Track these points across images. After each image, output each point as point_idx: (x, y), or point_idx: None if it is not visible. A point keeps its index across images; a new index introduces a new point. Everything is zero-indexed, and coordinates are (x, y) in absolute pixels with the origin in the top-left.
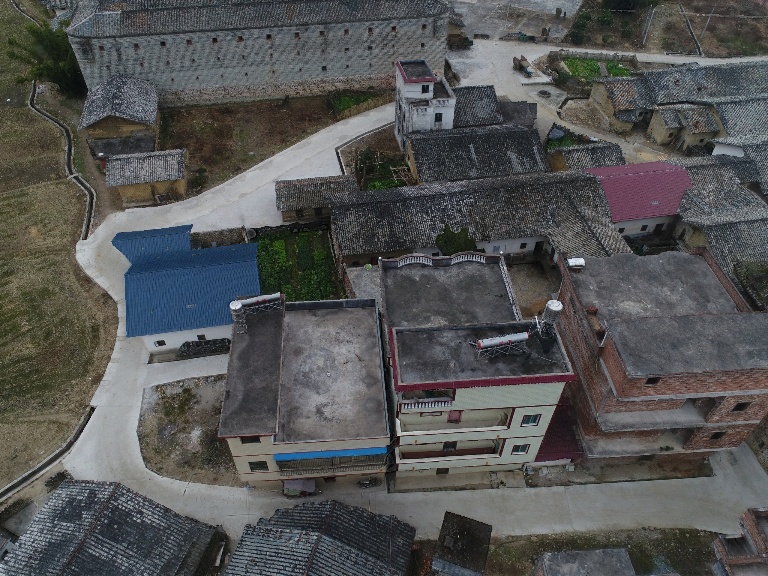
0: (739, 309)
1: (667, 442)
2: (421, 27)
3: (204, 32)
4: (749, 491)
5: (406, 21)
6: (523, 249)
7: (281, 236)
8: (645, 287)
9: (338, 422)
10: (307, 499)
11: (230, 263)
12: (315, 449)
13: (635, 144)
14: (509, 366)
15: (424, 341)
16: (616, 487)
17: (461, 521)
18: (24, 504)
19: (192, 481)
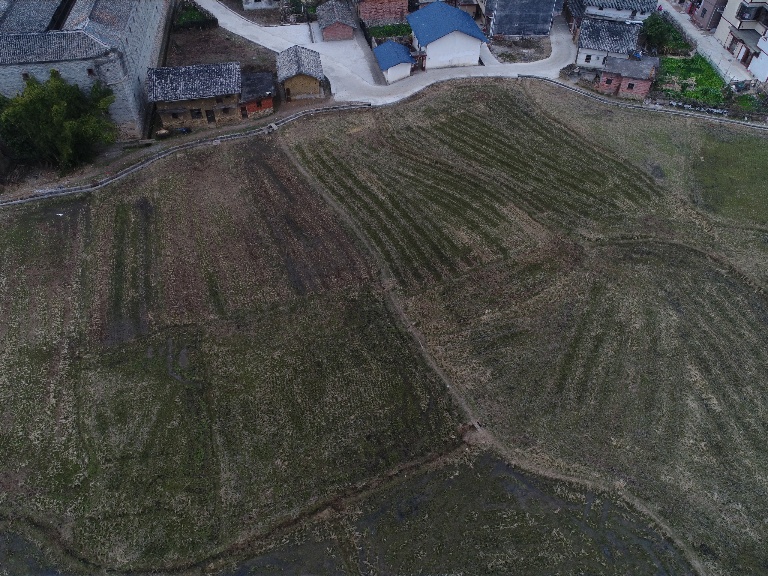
0: None
1: None
2: None
3: None
4: None
5: None
6: None
7: None
8: None
9: None
10: None
11: None
12: None
13: None
14: None
15: None
16: None
17: None
18: None
19: None
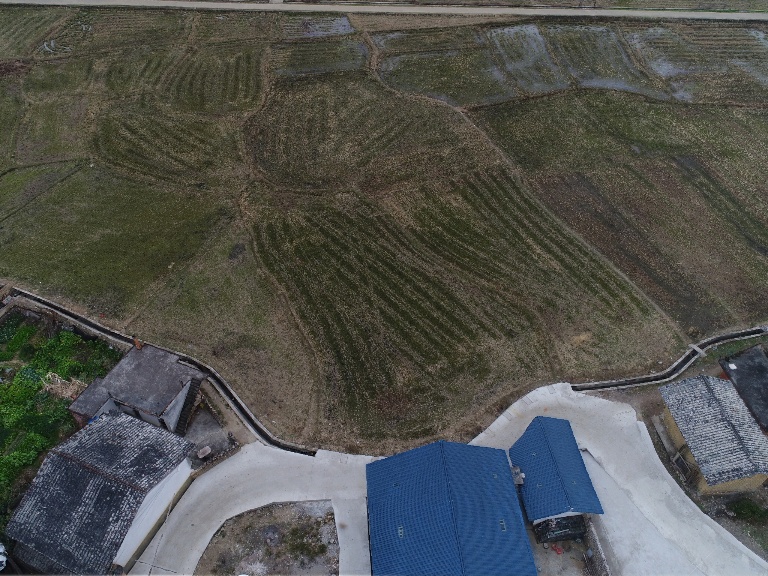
0: None
1: None
2: None
3: None
4: None
5: None
6: None
7: None
8: None
9: None
10: None
11: None
12: None
13: None
14: None
15: None
16: None
17: None
18: (219, 422)
19: (196, 572)
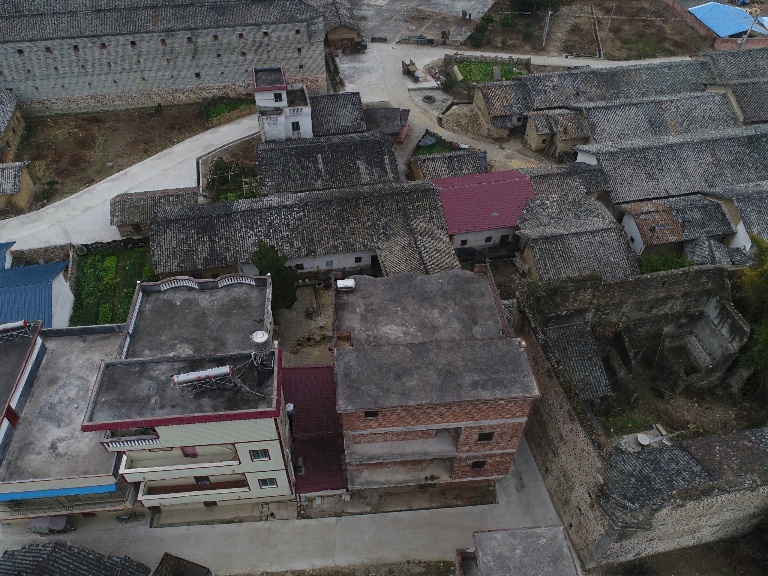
0: (504, 332)
1: (435, 471)
2: (295, 32)
3: (63, 39)
4: (528, 519)
5: (278, 26)
6: (359, 263)
7: (115, 252)
8: (414, 309)
9: (69, 458)
10: (56, 537)
11: (22, 284)
12: (36, 488)
13: (508, 151)
14: (213, 401)
15: (134, 375)
16: (391, 517)
17: (177, 564)
18: None
19: None
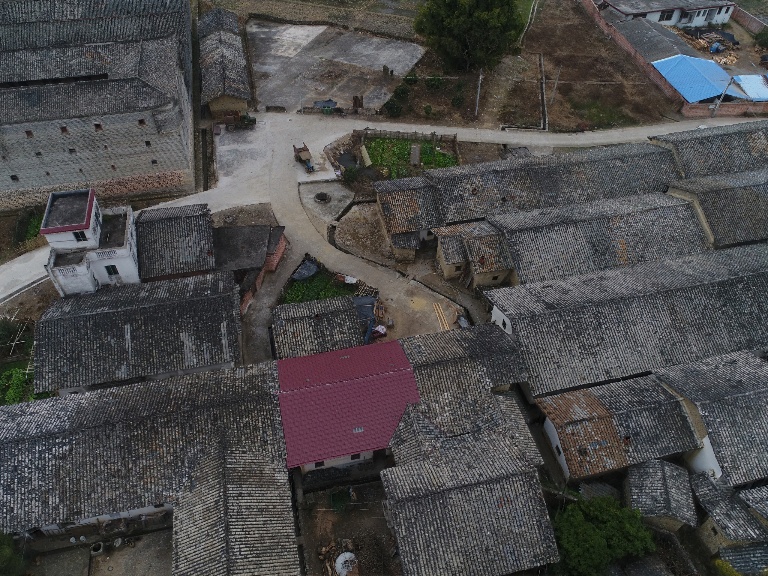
0: None
1: None
2: (137, 123)
3: None
4: None
5: (113, 117)
6: (162, 507)
7: None
8: None
9: None
10: None
11: None
12: None
13: (411, 282)
14: None
15: None
16: None
17: None
18: None
19: None
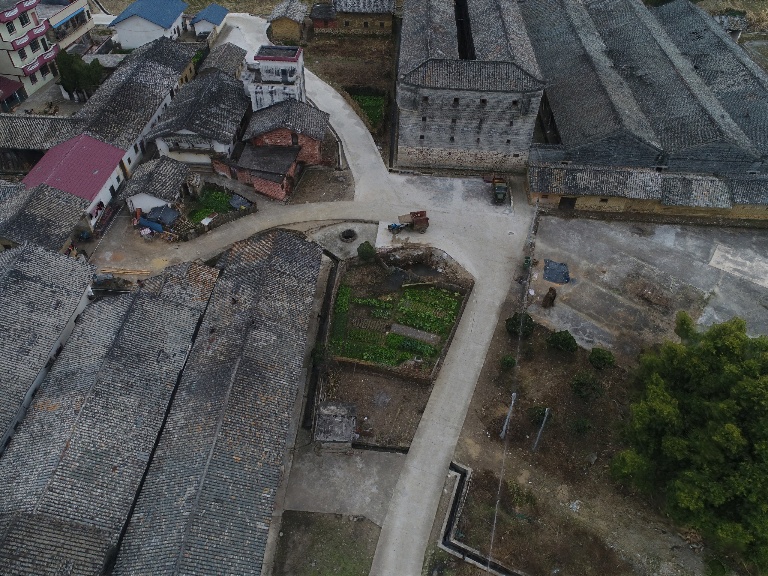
0: None
1: None
2: None
3: None
4: None
5: None
6: None
7: None
8: None
9: None
10: None
11: None
12: None
13: None
14: None
15: None
16: None
17: None
18: None
19: None
